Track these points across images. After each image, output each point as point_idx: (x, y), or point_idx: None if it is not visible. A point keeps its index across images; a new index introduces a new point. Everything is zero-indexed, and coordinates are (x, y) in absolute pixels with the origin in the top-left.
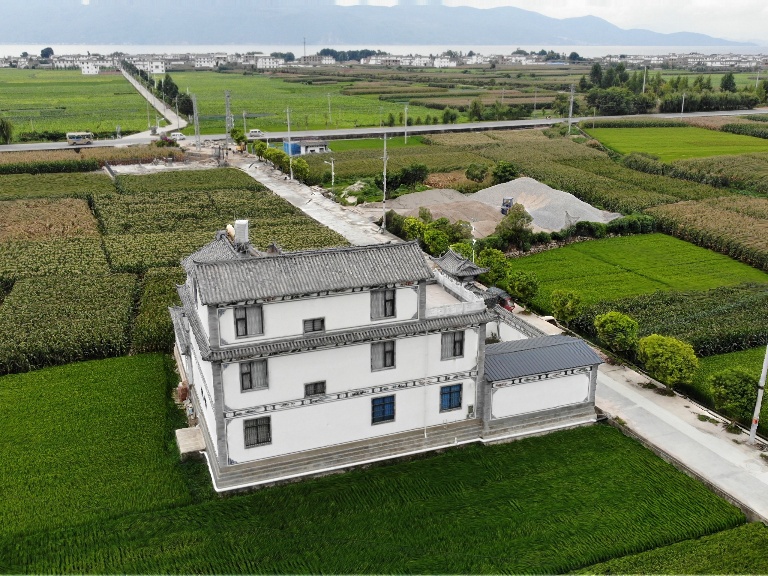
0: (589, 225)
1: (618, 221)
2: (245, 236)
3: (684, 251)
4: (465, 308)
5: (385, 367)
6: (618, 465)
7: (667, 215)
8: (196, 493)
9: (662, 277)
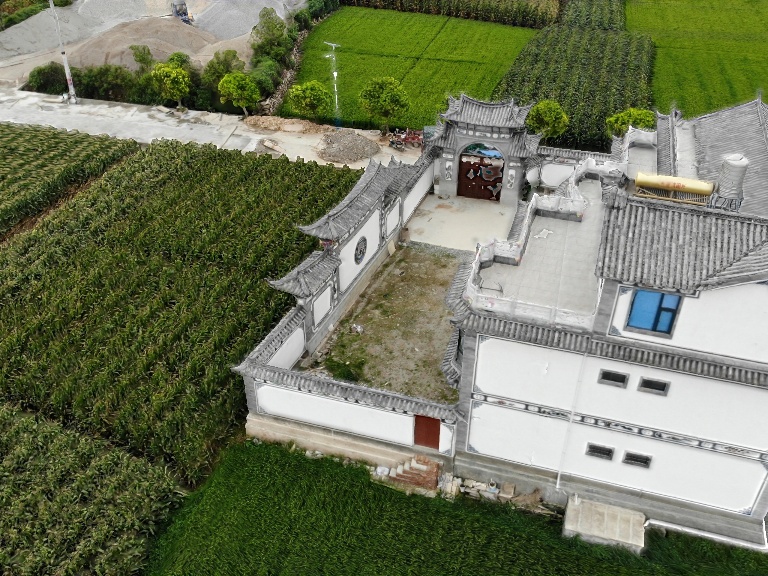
0: (304, 15)
1: (317, 2)
2: None
3: (408, 20)
4: None
5: None
6: None
7: None
8: (743, 573)
9: (454, 56)
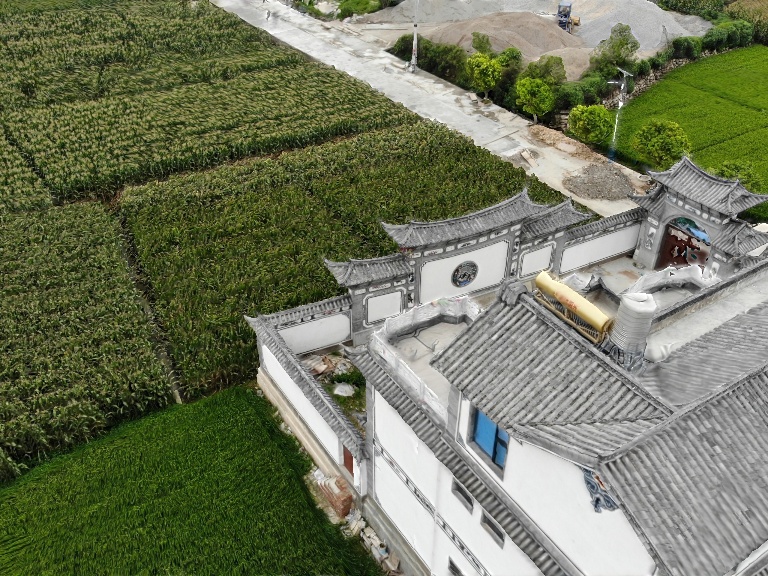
0: (688, 43)
1: (717, 33)
2: None
3: None
4: None
5: None
6: None
7: (761, 17)
8: None
9: None
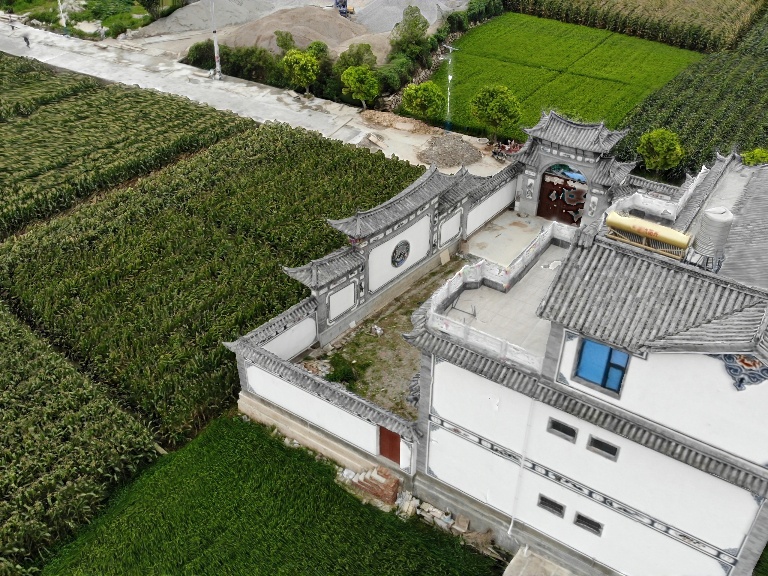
0: (459, 17)
1: (477, 6)
2: None
3: (567, 32)
4: None
5: None
6: None
7: None
8: None
9: (601, 73)
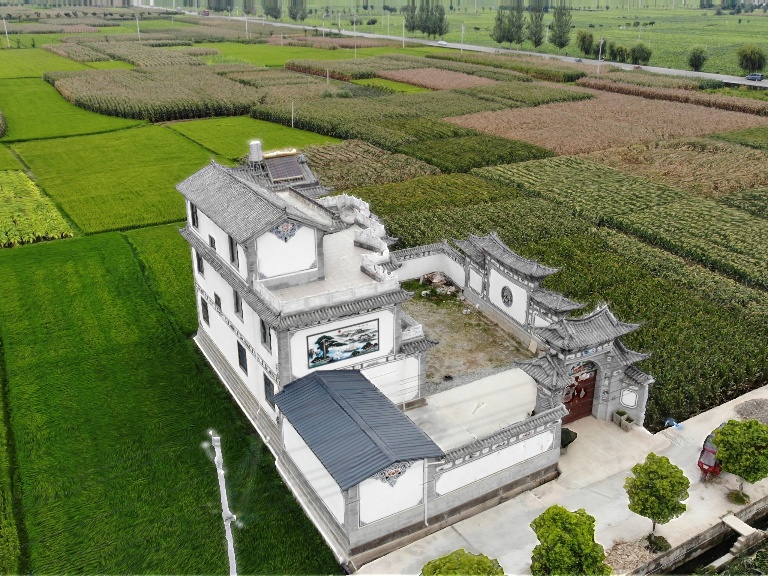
0: None
1: None
2: (254, 156)
3: None
4: (272, 301)
5: (242, 317)
6: (204, 568)
7: None
8: None
9: None
